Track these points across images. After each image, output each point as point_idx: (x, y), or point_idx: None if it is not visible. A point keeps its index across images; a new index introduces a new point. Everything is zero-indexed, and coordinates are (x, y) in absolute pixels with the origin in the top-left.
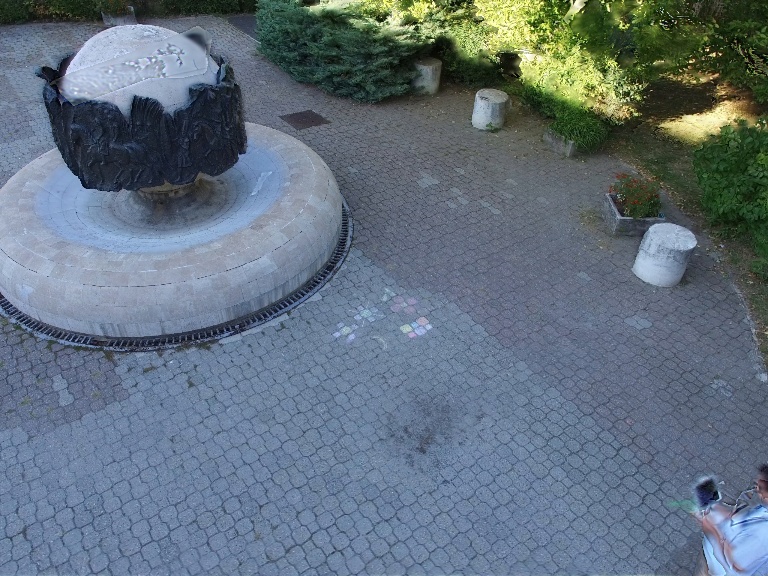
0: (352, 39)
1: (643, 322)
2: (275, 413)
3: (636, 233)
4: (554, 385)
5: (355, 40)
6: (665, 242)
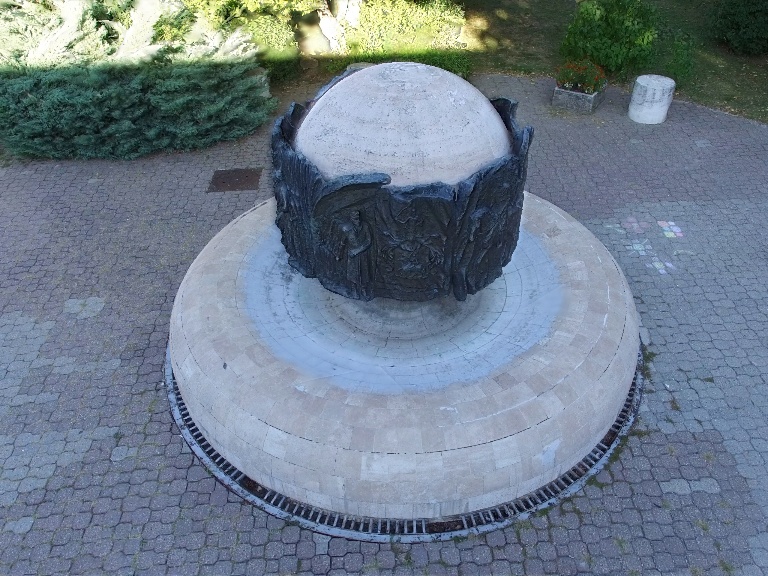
0: (201, 72)
1: (704, 142)
2: (767, 336)
3: (598, 103)
4: (765, 196)
5: (204, 72)
6: (663, 86)
